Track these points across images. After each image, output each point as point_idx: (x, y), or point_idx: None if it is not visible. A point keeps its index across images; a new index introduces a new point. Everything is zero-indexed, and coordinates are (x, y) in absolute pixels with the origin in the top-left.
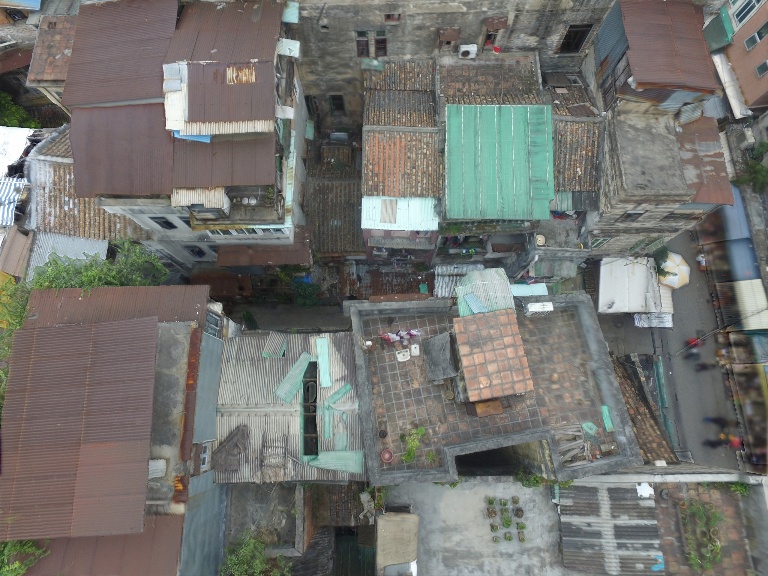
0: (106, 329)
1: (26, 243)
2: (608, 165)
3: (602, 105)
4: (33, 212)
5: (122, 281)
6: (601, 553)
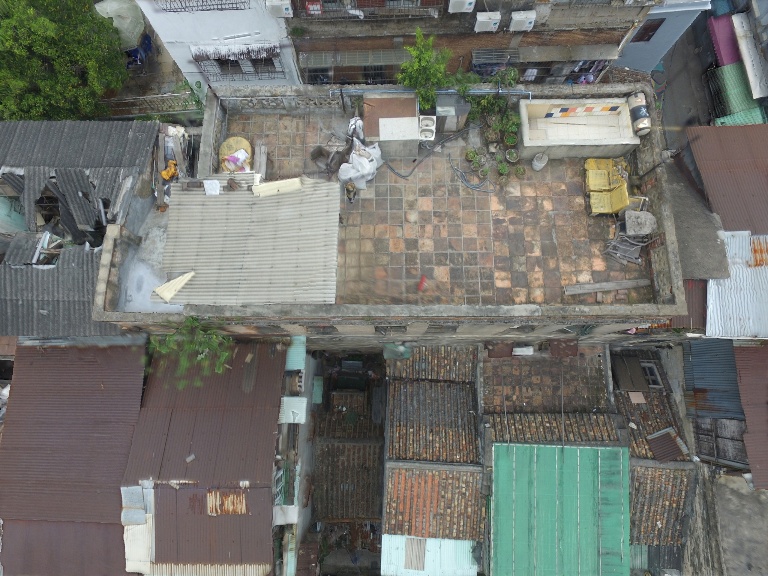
0: None
1: None
2: (700, 536)
3: (693, 444)
4: None
5: None
6: None
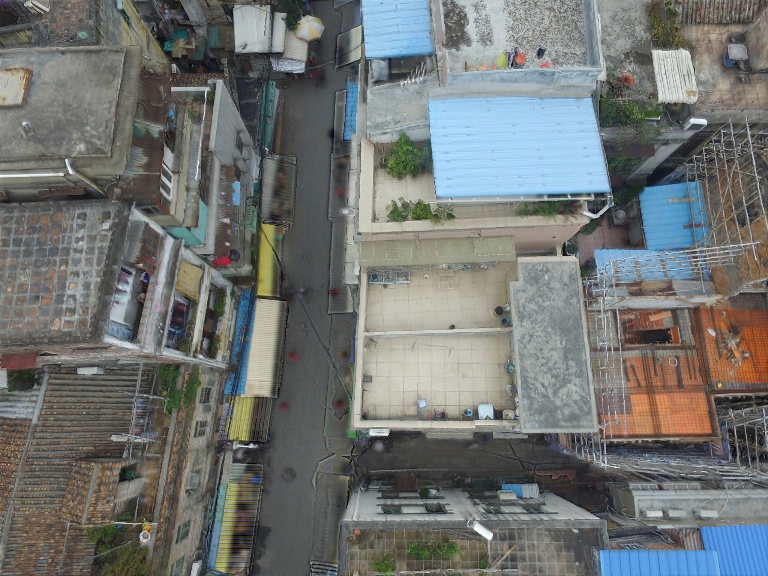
0: None
1: None
2: None
3: None
4: None
5: None
6: None
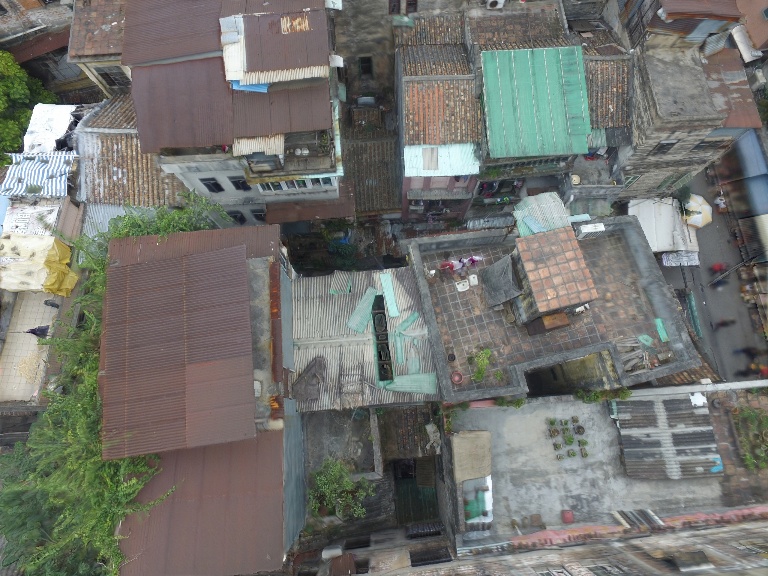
0: (197, 260)
1: (78, 214)
2: (640, 99)
3: (629, 43)
4: (82, 184)
5: (191, 230)
6: (662, 460)
